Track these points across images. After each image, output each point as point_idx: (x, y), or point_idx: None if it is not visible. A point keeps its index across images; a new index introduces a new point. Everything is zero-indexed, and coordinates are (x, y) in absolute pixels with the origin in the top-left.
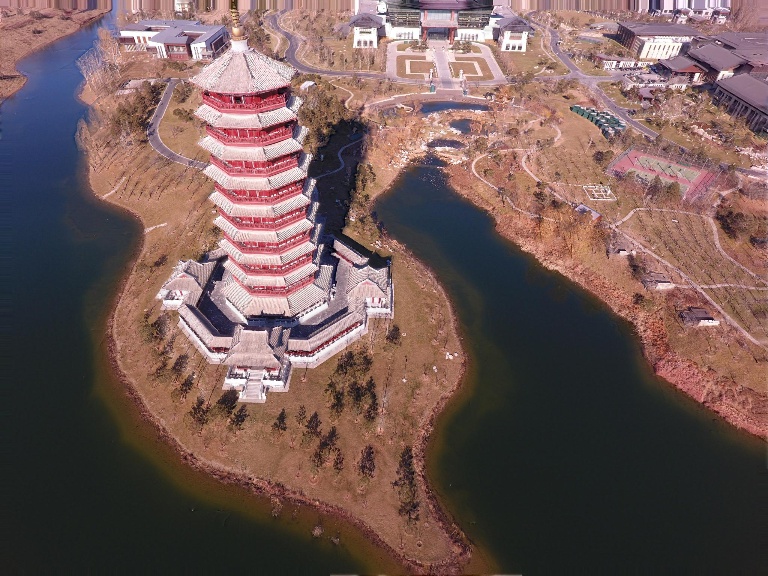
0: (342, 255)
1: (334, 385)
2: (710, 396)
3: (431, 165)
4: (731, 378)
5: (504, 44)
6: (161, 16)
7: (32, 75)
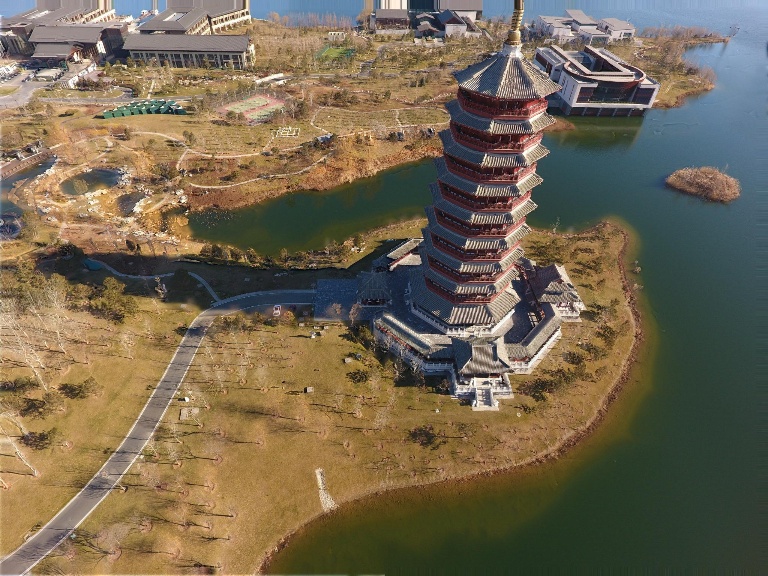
0: (394, 262)
1: (543, 263)
2: None
3: None
4: None
5: None
6: None
7: None
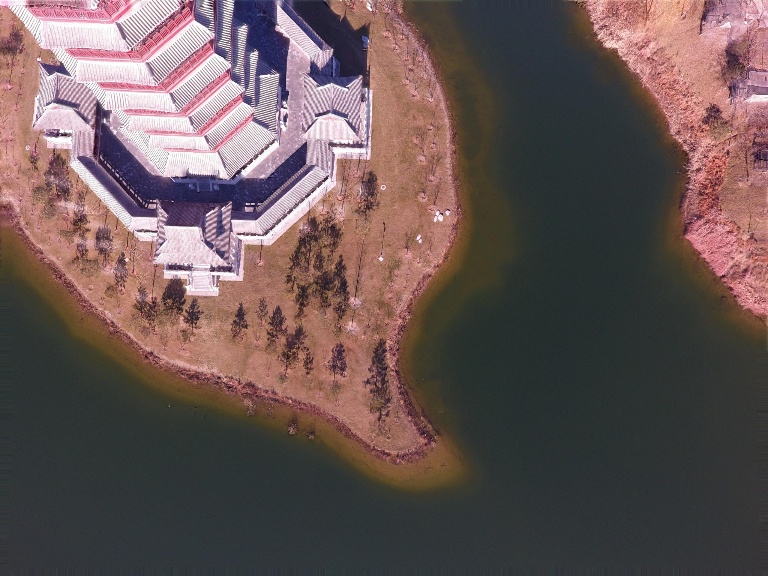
0: None
1: None
2: (733, 270)
3: None
4: None
5: None
6: None
7: None
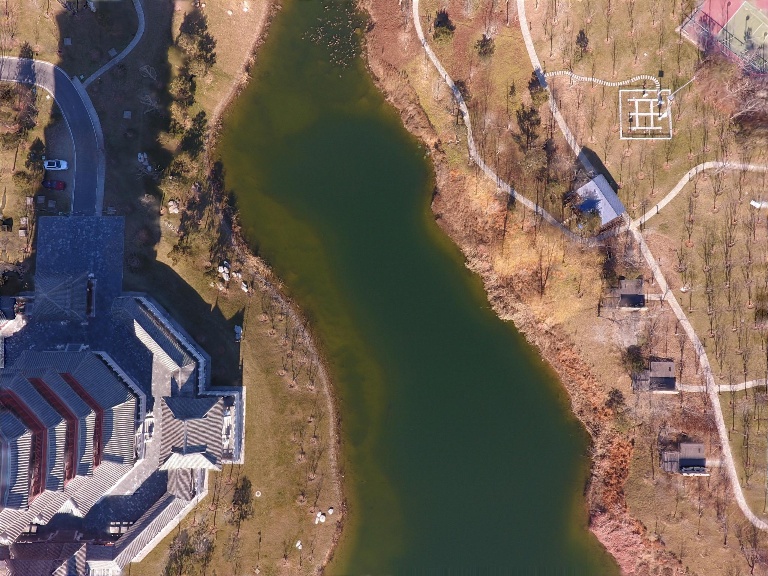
0: None
1: None
2: (642, 568)
3: None
4: (679, 557)
5: None
6: None
7: None
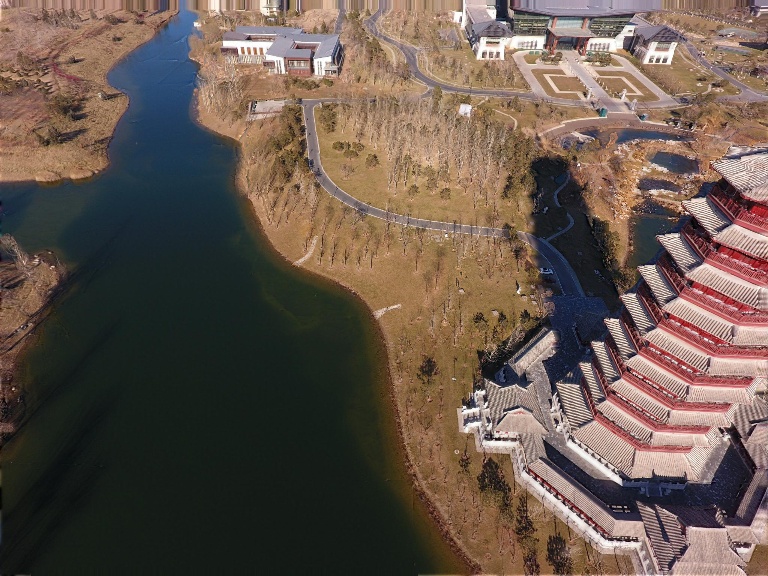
0: None
1: None
2: None
3: (659, 215)
4: None
5: (648, 56)
6: (249, 21)
7: (131, 92)
